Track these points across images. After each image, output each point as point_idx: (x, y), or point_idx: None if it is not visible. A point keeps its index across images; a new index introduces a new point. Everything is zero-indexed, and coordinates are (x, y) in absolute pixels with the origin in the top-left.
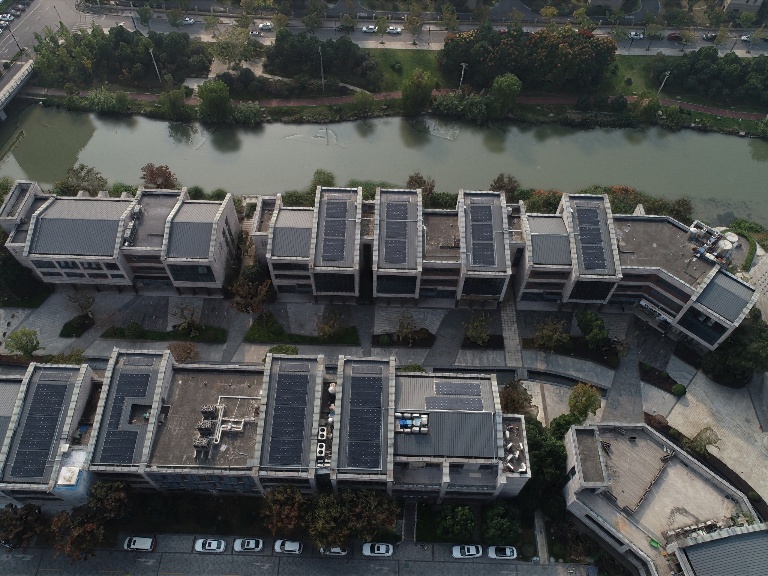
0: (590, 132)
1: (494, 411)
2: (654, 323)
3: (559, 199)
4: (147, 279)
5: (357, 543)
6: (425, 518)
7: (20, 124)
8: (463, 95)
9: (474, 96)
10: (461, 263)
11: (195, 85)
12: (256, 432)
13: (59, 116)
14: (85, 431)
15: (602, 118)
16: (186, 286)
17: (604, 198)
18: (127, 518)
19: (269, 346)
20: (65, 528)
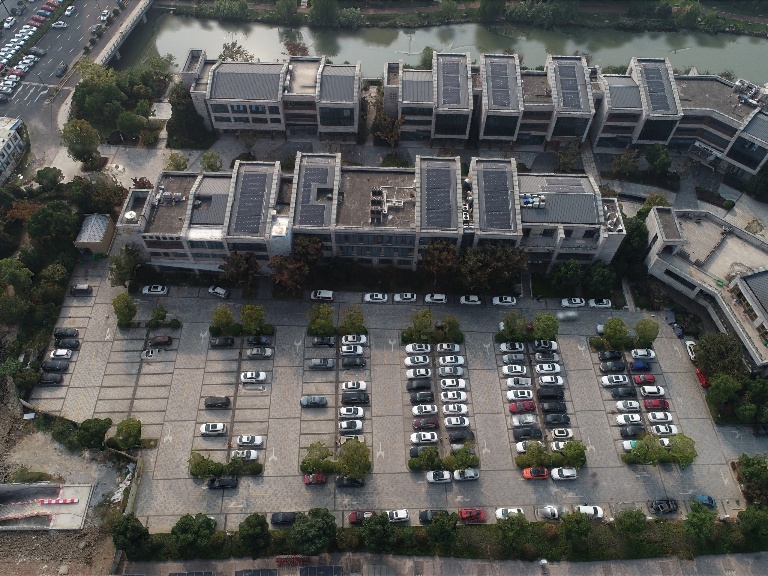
0: (640, 35)
1: (594, 193)
2: (705, 162)
3: (625, 69)
4: (297, 126)
5: (487, 298)
6: (538, 282)
7: (157, 28)
8: (532, 4)
9: (541, 5)
10: (554, 105)
11: None
12: (413, 208)
13: (189, 22)
14: (282, 208)
15: (650, 23)
16: (328, 131)
17: (665, 60)
18: (311, 279)
19: None
20: (278, 268)
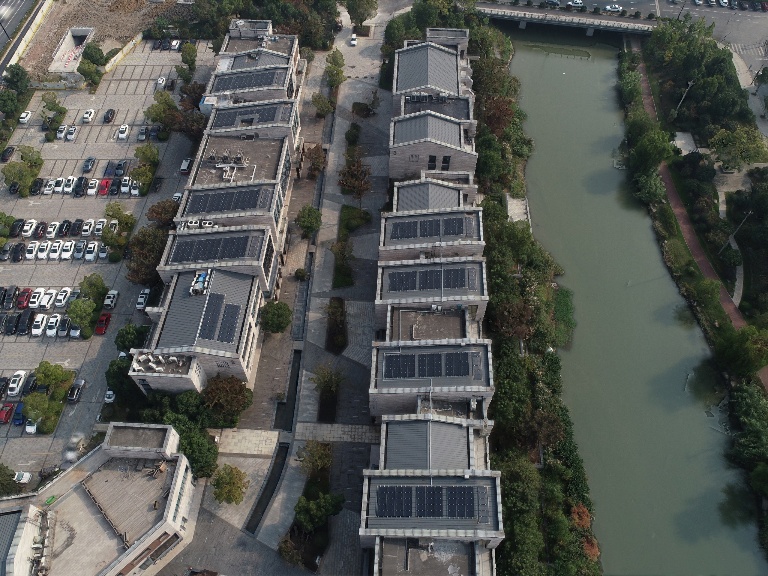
0: None
1: None
2: None
3: (524, 496)
4: None
5: (154, 287)
6: None
7: (590, 47)
8: None
9: None
10: (385, 341)
11: (681, 141)
12: None
13: (607, 66)
14: None
15: None
16: None
17: None
18: None
19: (337, 223)
20: None
